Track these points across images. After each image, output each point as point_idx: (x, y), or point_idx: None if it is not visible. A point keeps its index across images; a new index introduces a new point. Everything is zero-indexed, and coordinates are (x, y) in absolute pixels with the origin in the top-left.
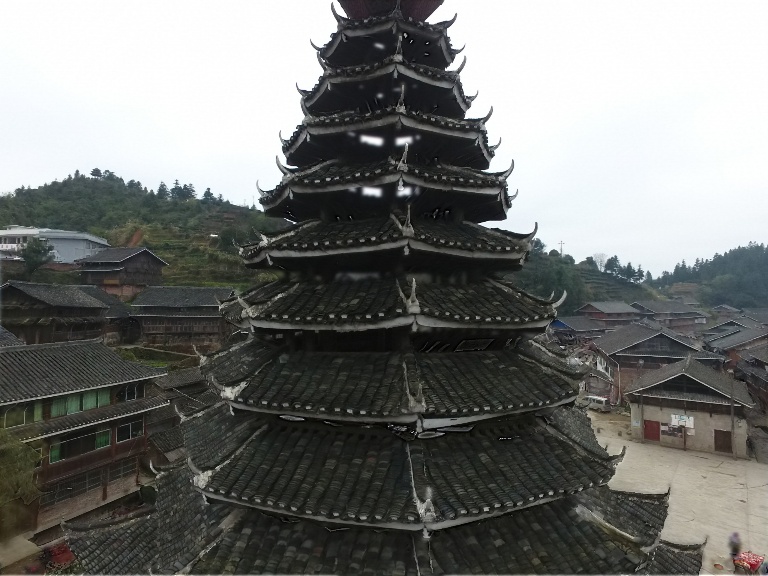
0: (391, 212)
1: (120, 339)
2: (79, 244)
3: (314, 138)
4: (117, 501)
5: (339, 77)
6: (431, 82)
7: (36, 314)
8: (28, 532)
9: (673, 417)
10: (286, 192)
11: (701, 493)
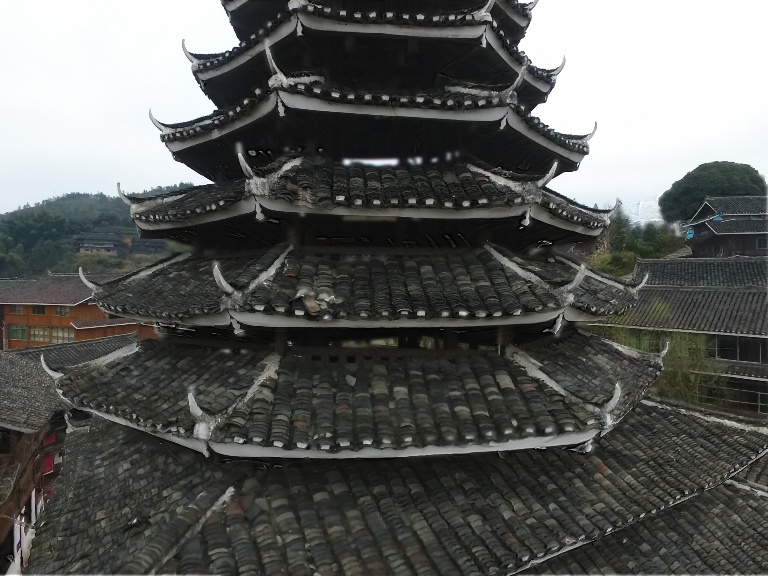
0: None
1: None
2: None
3: None
4: None
5: None
6: None
7: None
8: None
9: None
10: None
11: None
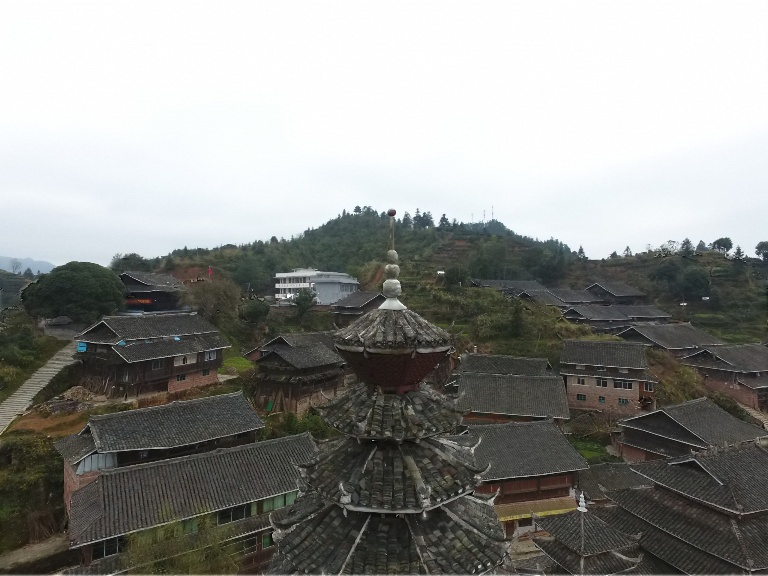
0: None
1: (357, 379)
2: (336, 287)
3: None
4: None
5: None
6: (392, 511)
7: (289, 373)
8: None
9: None
10: None
11: None
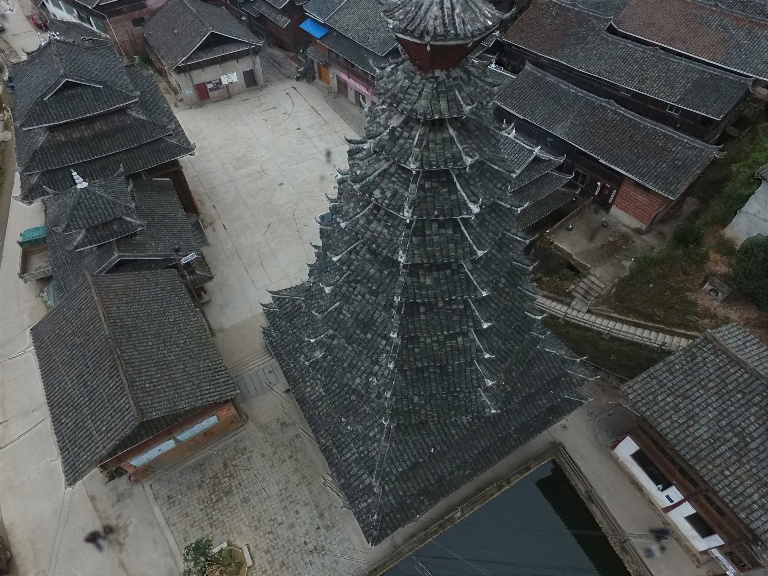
0: None
1: None
2: None
3: None
4: None
5: None
6: None
7: None
8: None
9: (222, 78)
10: None
11: (279, 137)
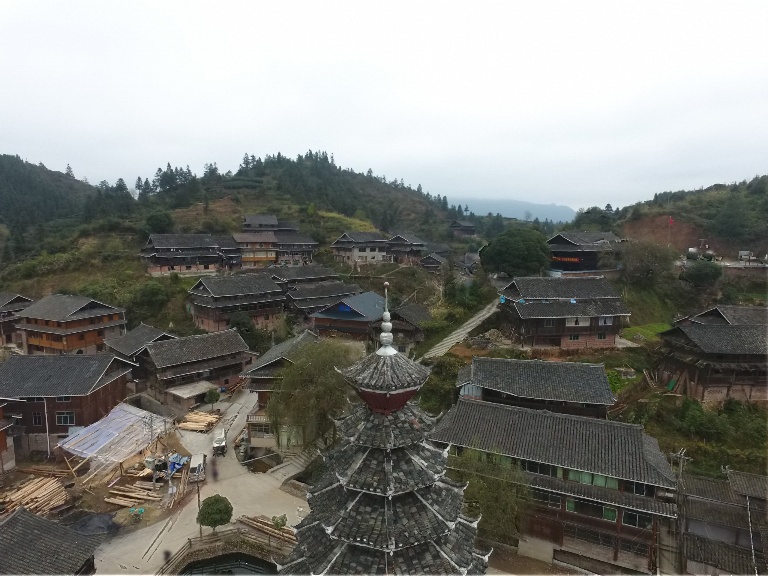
0: None
1: None
2: None
3: None
4: (628, 569)
5: None
6: None
7: (697, 355)
8: (557, 545)
9: None
10: None
11: None
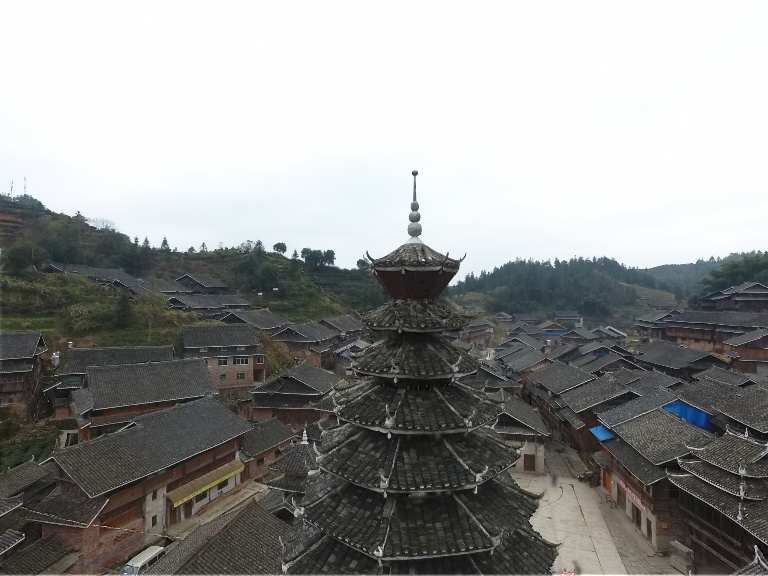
0: (455, 494)
1: None
2: None
3: (393, 435)
4: None
5: (405, 375)
6: None
7: None
8: None
9: None
10: (379, 490)
11: None
